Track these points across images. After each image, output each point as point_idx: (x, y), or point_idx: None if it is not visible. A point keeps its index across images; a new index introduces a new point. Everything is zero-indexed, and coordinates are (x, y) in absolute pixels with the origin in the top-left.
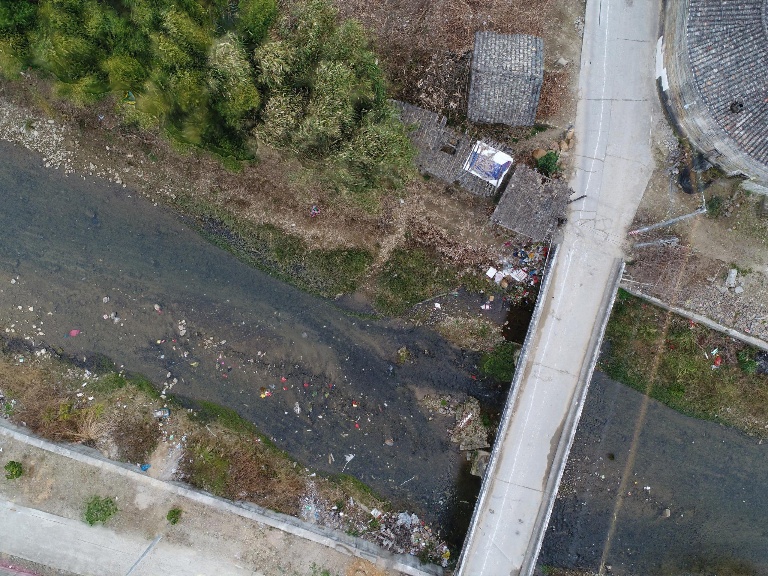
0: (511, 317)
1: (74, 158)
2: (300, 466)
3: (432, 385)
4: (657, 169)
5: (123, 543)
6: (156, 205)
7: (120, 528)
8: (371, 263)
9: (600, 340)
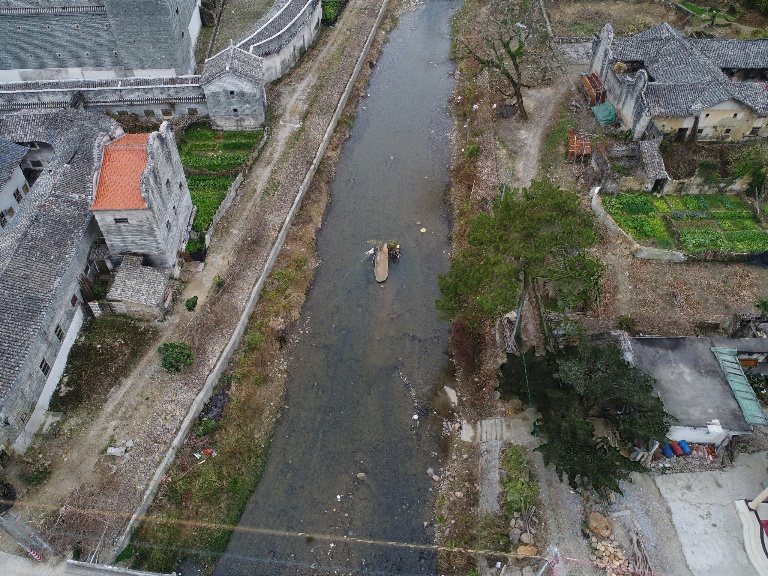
0: None
1: None
2: None
3: None
4: None
5: None
6: None
7: None
8: None
9: (153, 575)
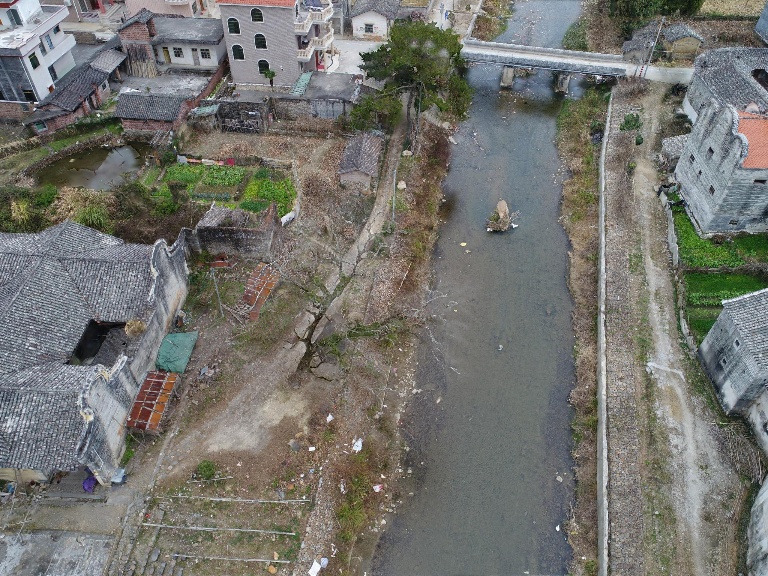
0: (579, 79)
1: (587, 5)
2: (490, 41)
3: None
4: (674, 84)
5: (454, 2)
6: (579, 17)
7: None
8: (583, 51)
9: None
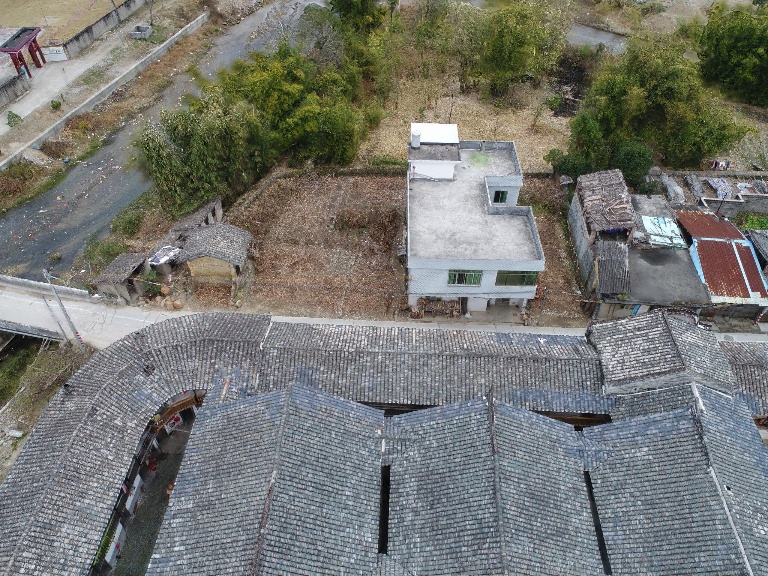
0: None
1: None
2: (2, 213)
3: (25, 272)
4: None
5: None
6: None
7: (3, 137)
8: None
9: None
